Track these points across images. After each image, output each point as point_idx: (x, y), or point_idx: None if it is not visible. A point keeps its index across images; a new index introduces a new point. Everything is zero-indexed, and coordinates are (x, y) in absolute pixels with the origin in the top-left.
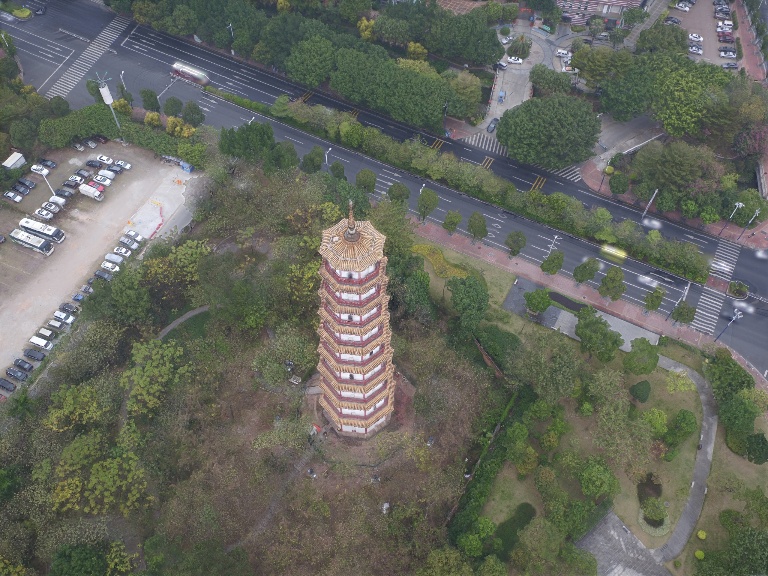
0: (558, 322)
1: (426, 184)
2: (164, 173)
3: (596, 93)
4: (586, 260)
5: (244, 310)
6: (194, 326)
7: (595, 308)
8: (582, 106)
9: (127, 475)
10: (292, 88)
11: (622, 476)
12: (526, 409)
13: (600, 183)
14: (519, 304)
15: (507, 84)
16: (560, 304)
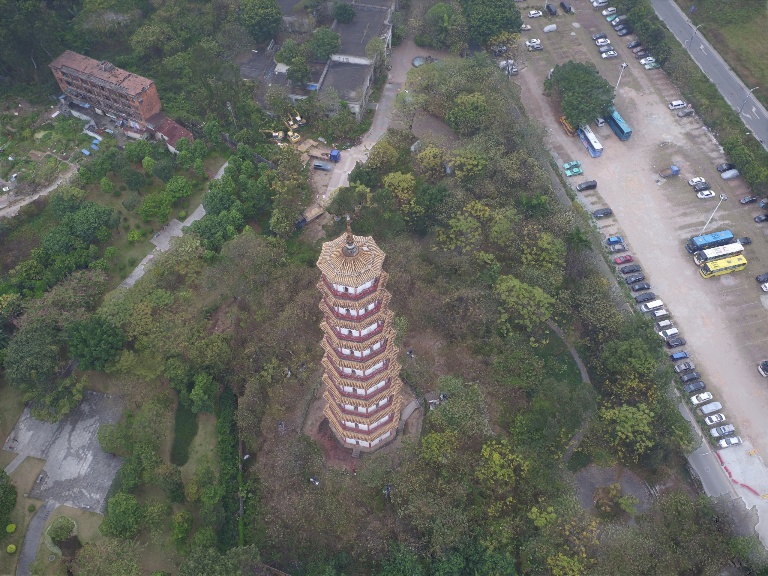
0: None
1: None
2: None
3: None
4: None
5: None
6: None
7: None
8: None
9: None
10: None
11: None
12: (223, 547)
13: None
14: None
15: None
16: None
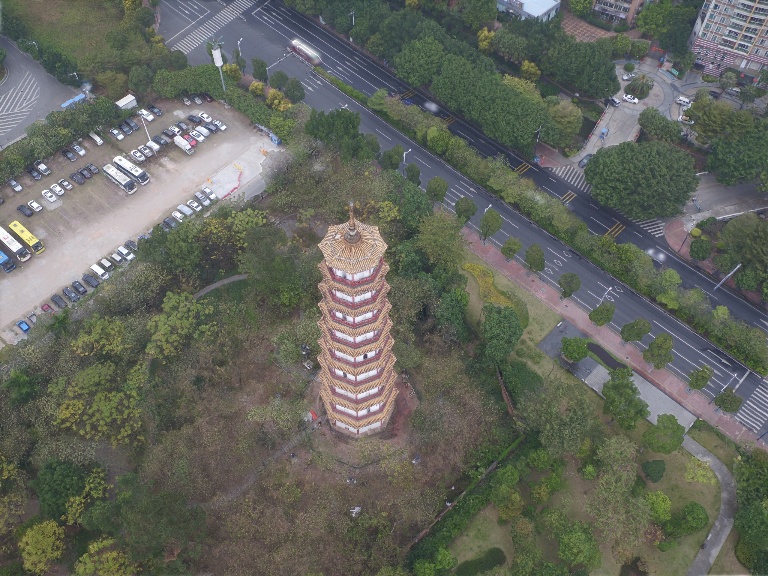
0: (591, 376)
1: (499, 205)
2: (254, 141)
3: (708, 149)
4: (636, 320)
5: (281, 286)
6: (236, 290)
7: (635, 371)
8: (682, 160)
9: (124, 411)
10: (397, 84)
11: (609, 551)
12: (528, 455)
13: (682, 244)
14: (556, 347)
15: (614, 122)
16: (599, 358)
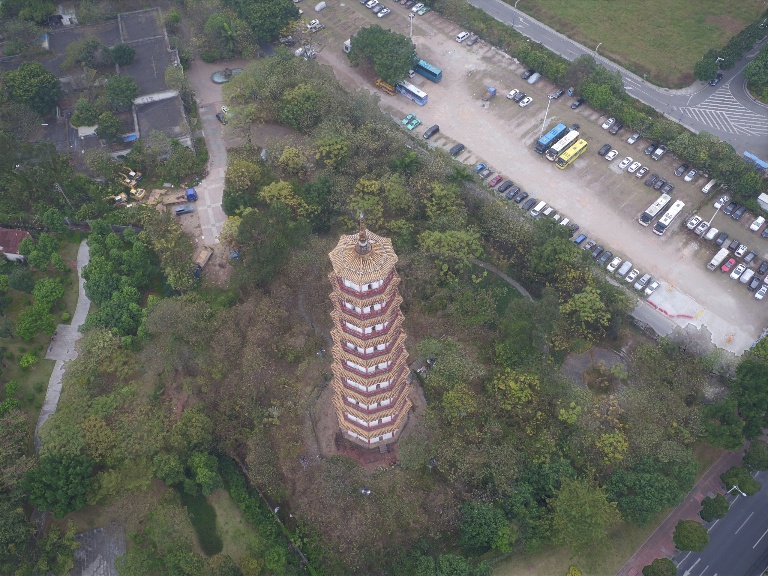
0: None
1: None
2: (747, 329)
3: None
4: None
5: None
6: None
7: None
8: None
9: None
10: None
11: None
12: None
13: None
14: None
15: None
16: None
